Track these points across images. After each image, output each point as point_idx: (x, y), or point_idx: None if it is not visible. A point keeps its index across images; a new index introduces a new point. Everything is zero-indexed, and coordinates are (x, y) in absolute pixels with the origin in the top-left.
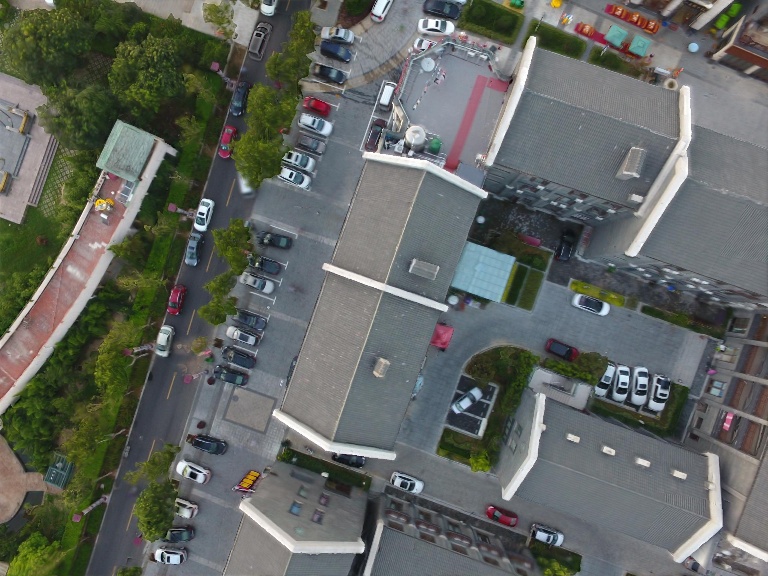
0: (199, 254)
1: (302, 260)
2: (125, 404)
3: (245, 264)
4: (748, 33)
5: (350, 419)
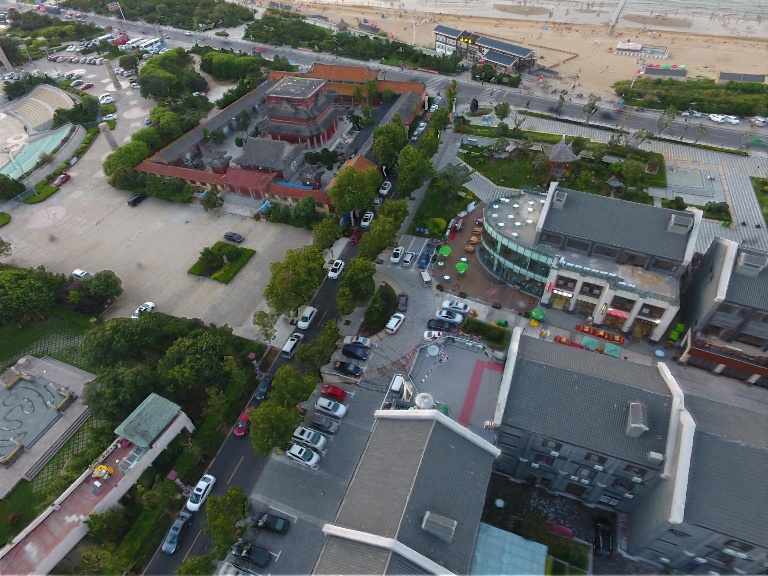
0: (181, 538)
1: (297, 549)
2: None
3: (232, 540)
4: None
5: None
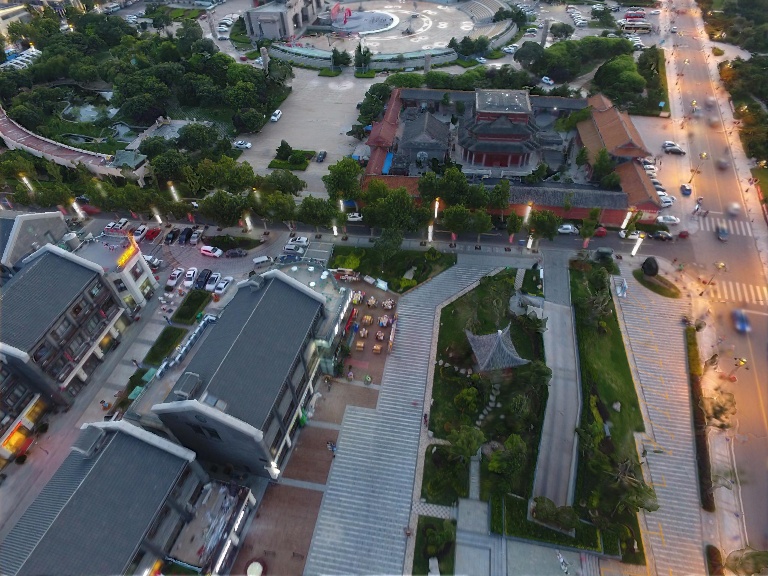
0: (79, 201)
1: None
2: (3, 186)
3: (45, 202)
4: None
5: None
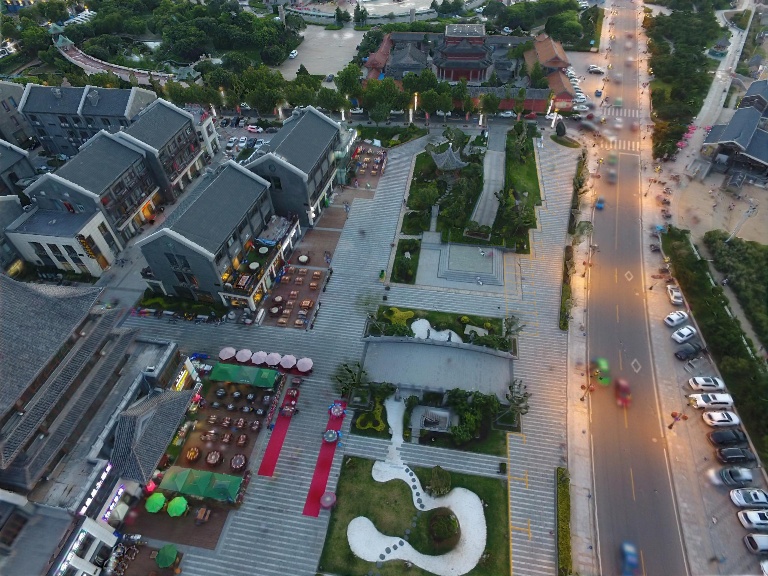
0: None
1: None
2: None
3: None
4: None
5: (39, 91)
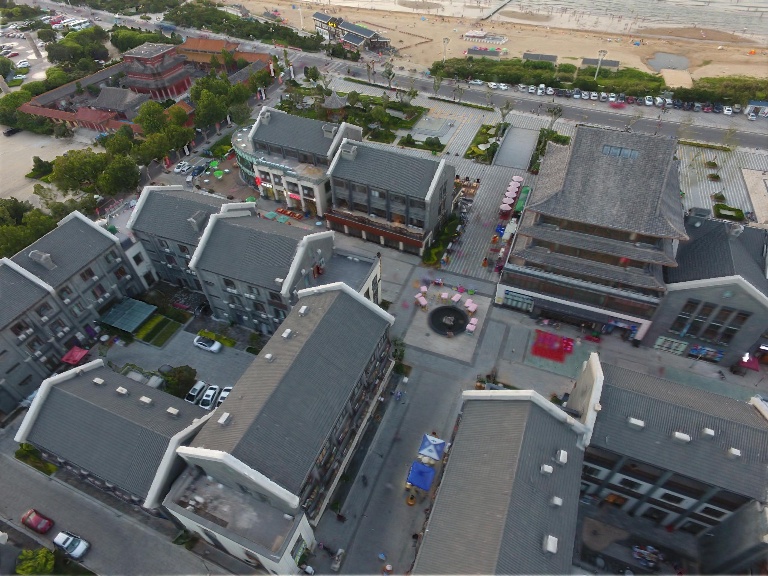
0: None
1: None
2: None
3: None
4: (334, 209)
5: None
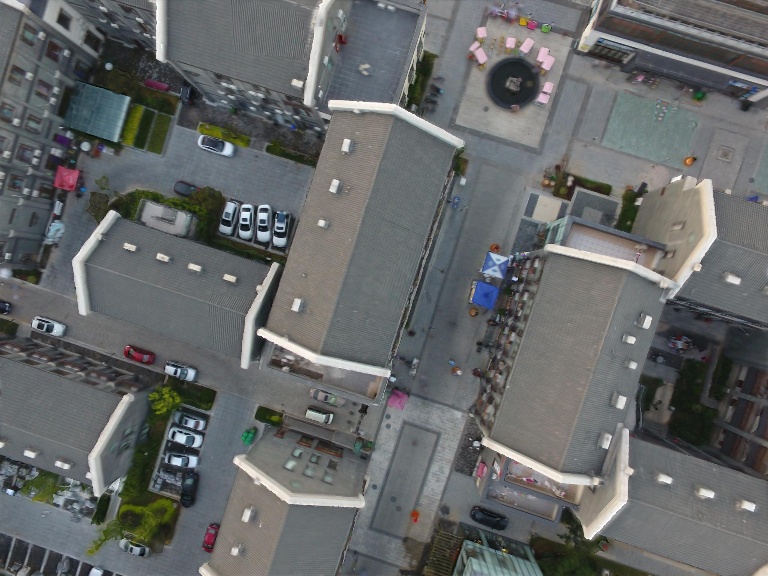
0: None
1: None
2: None
3: None
4: None
5: None
